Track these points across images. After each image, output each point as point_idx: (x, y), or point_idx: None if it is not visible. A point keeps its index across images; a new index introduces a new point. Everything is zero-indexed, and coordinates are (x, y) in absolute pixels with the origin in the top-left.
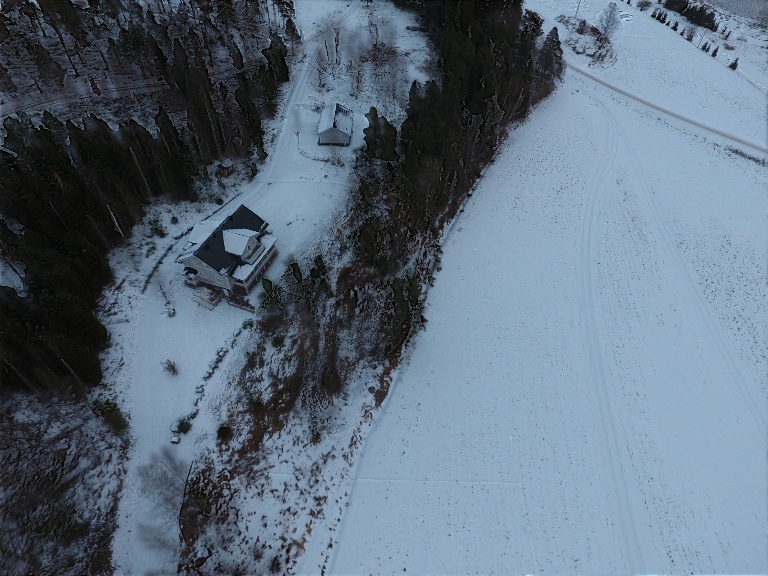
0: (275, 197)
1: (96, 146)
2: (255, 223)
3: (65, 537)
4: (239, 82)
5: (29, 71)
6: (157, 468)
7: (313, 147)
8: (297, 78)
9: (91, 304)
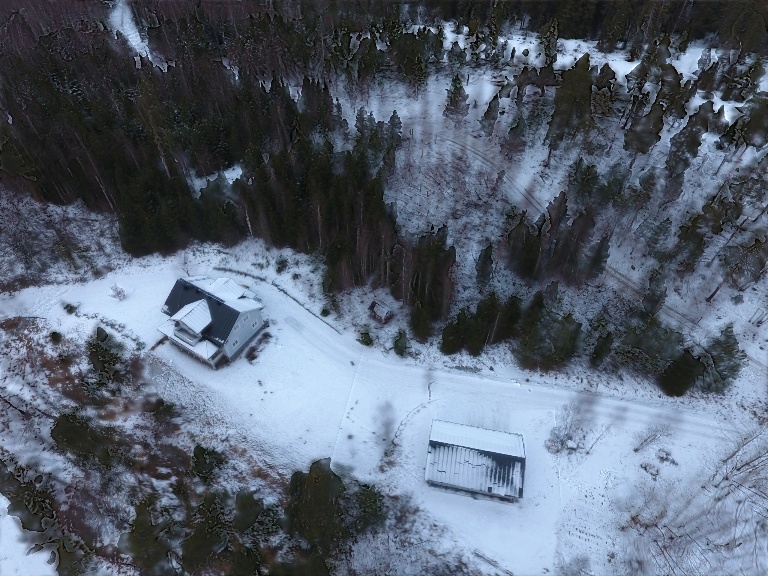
0: (320, 368)
1: (341, 189)
2: (221, 330)
3: (43, 263)
4: (530, 296)
5: (543, 137)
6: (58, 300)
7: (429, 422)
8: (681, 409)
9: (198, 237)
